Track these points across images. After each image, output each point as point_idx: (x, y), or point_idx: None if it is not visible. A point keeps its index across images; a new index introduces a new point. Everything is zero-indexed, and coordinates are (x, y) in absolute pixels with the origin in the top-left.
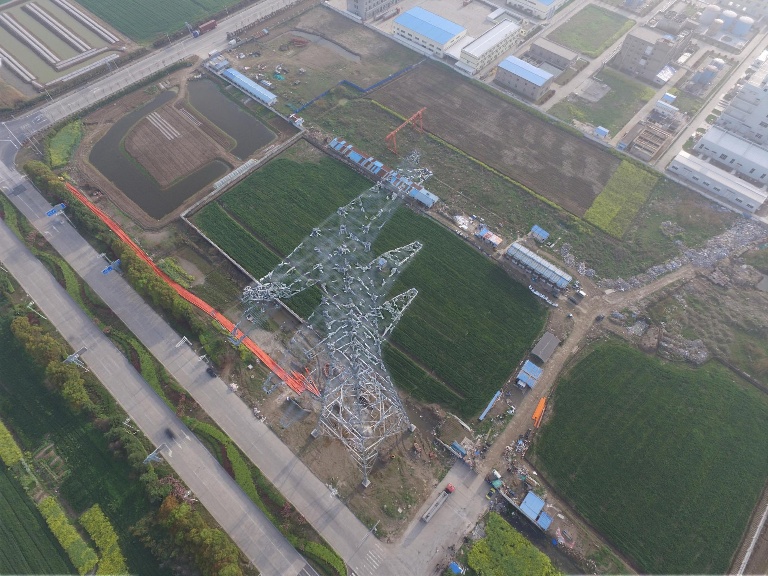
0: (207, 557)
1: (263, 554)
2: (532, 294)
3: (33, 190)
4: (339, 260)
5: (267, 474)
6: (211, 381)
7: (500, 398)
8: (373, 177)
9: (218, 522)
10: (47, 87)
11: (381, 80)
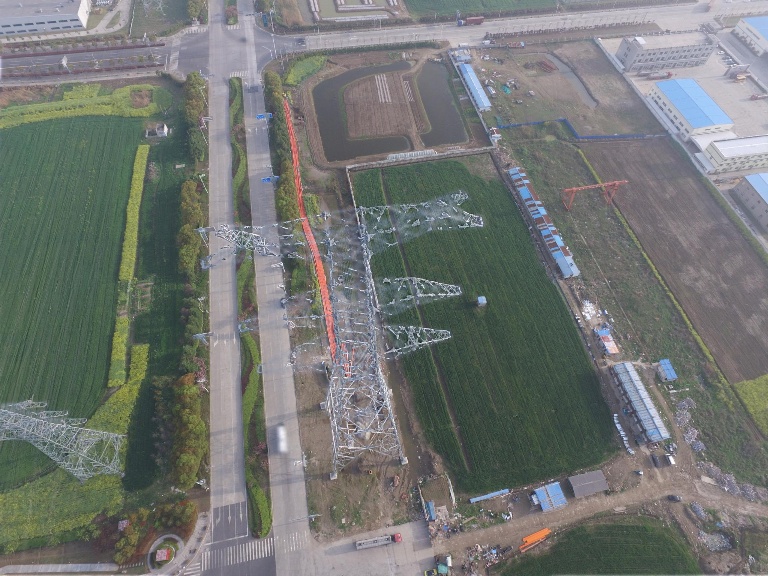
0: (183, 437)
1: (222, 467)
2: (613, 424)
3: (262, 94)
4: (445, 276)
5: (267, 410)
6: (279, 309)
7: (504, 496)
8: (529, 220)
9: (210, 418)
10: (322, 21)
11: (603, 135)
